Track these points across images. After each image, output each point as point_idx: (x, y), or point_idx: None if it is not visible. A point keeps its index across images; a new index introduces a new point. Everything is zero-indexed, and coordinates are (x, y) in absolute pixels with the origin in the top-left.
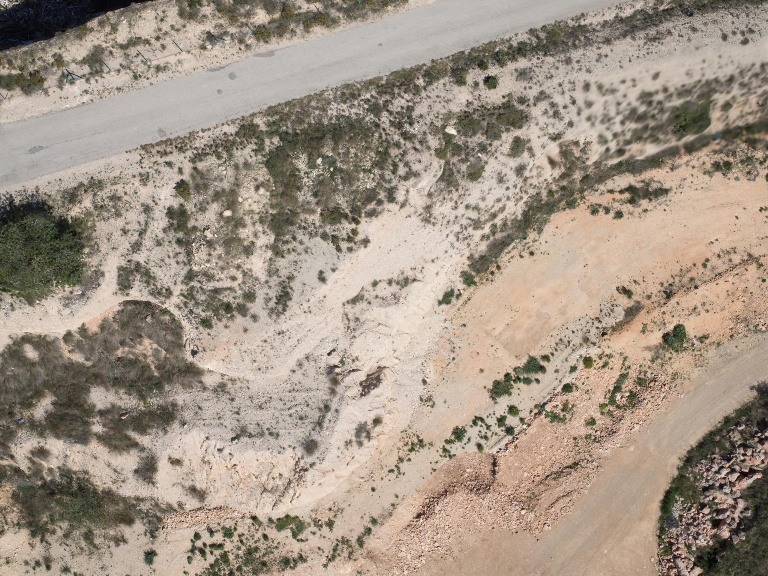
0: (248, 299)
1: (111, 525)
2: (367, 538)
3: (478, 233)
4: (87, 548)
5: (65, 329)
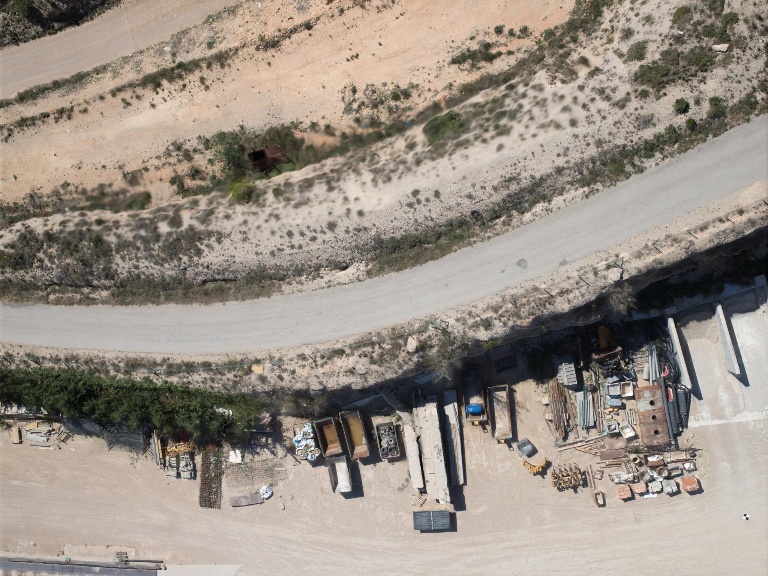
0: None
1: None
2: None
3: None
4: None
5: None
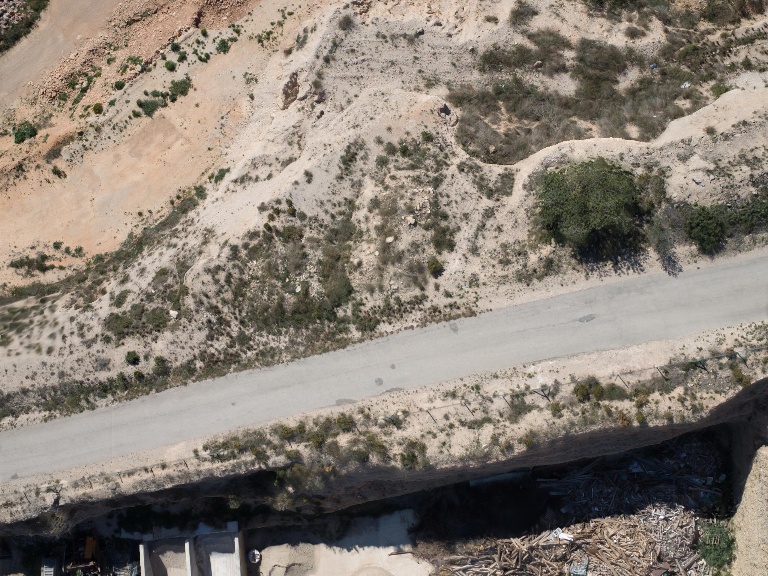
0: (384, 159)
1: None
2: None
3: None
4: None
5: None
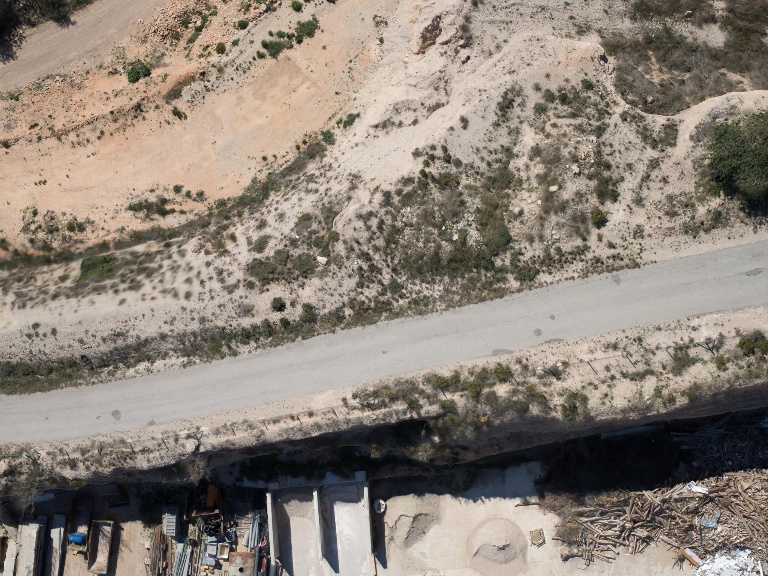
0: (542, 107)
1: None
2: None
3: None
4: None
5: None
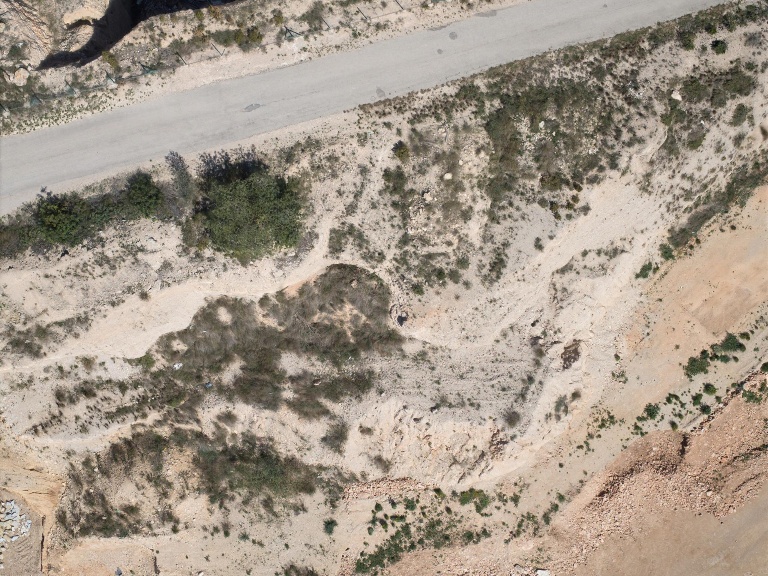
0: (461, 265)
1: (291, 493)
2: (554, 514)
3: (687, 204)
4: (266, 516)
5: (266, 292)
